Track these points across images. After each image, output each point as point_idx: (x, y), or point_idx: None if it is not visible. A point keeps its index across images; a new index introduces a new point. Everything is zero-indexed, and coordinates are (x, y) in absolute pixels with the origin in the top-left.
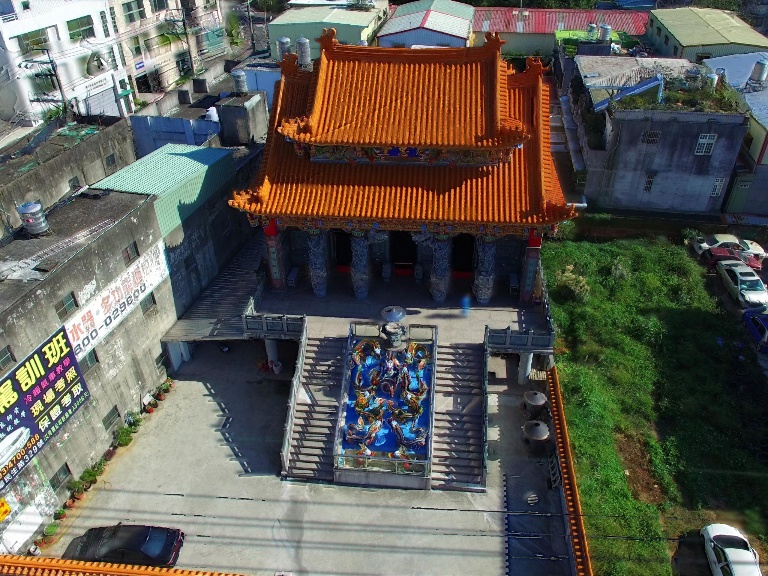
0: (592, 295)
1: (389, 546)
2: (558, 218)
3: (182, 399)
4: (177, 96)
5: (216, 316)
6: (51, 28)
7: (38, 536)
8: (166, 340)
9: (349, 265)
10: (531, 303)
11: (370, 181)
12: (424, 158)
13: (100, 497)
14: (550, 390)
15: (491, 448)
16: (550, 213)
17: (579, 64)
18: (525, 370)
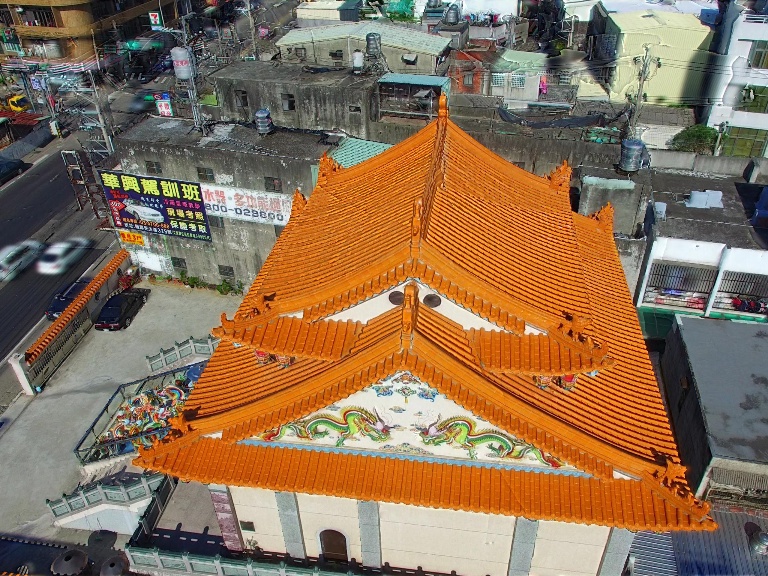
0: None
1: (47, 446)
2: None
3: None
4: (746, 165)
5: None
6: None
7: (158, 275)
8: None
9: None
10: (229, 551)
11: None
12: None
13: (179, 292)
14: None
15: (104, 537)
16: None
17: None
18: None
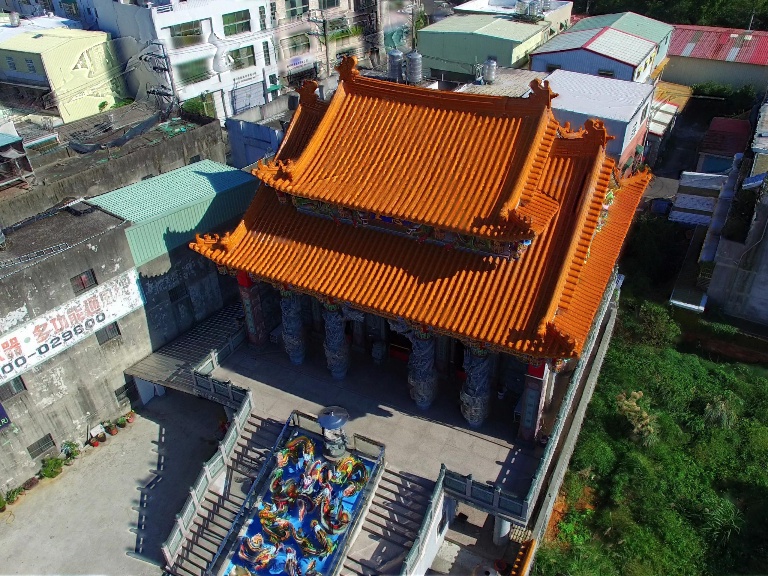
0: (662, 438)
1: None
2: (554, 353)
3: (131, 439)
4: (287, 101)
5: (187, 358)
6: (206, 20)
7: None
8: (128, 373)
9: None
10: (532, 443)
11: (349, 248)
12: (413, 233)
13: None
14: (510, 574)
15: None
16: (549, 342)
17: (762, 116)
18: (499, 529)
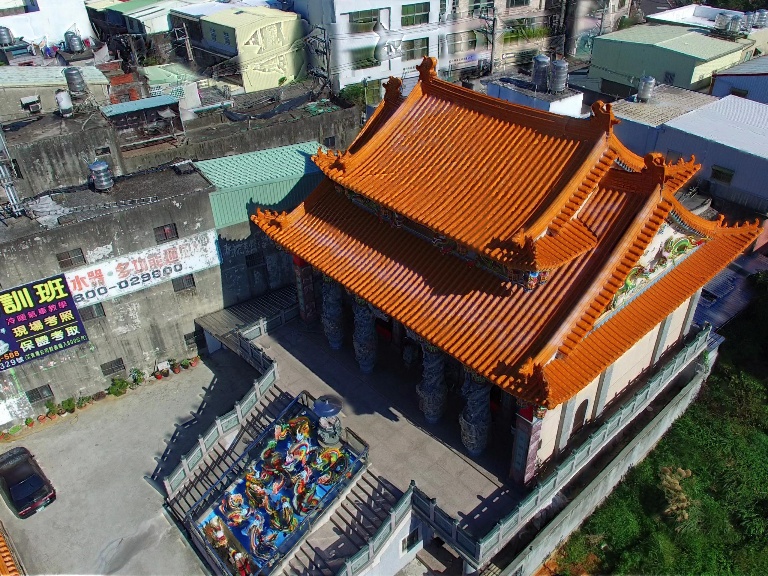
0: (703, 528)
1: None
2: (529, 397)
3: (187, 381)
4: None
5: (247, 320)
6: (385, 10)
7: (5, 429)
8: (197, 322)
9: (388, 329)
10: (521, 487)
11: (383, 246)
12: (438, 243)
13: (62, 426)
14: None
15: None
16: (531, 384)
17: None
18: (465, 564)
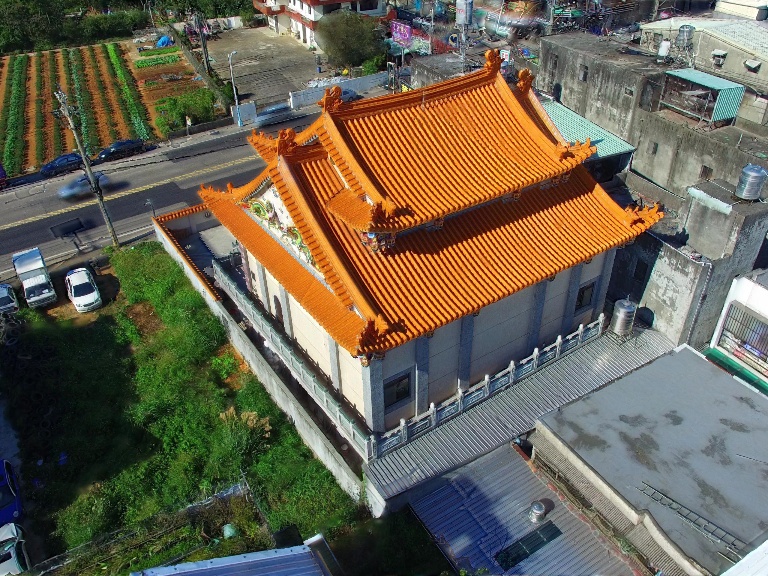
0: None
1: None
2: None
3: None
4: None
5: None
6: None
7: None
8: None
9: None
10: None
11: None
12: None
13: None
14: None
15: None
16: None
17: None
18: None
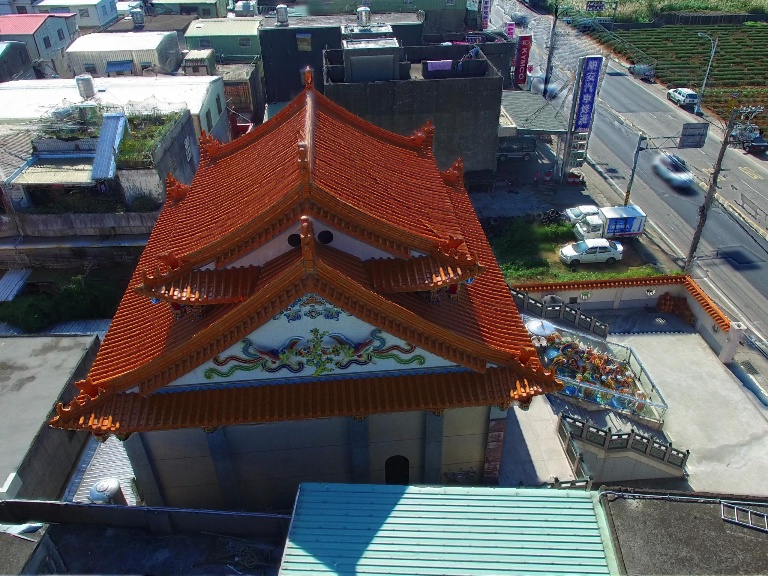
0: None
1: (691, 390)
2: None
3: None
4: None
5: None
6: None
7: None
8: None
9: None
10: None
11: None
12: None
13: None
14: None
15: None
16: (455, 179)
17: None
18: None
